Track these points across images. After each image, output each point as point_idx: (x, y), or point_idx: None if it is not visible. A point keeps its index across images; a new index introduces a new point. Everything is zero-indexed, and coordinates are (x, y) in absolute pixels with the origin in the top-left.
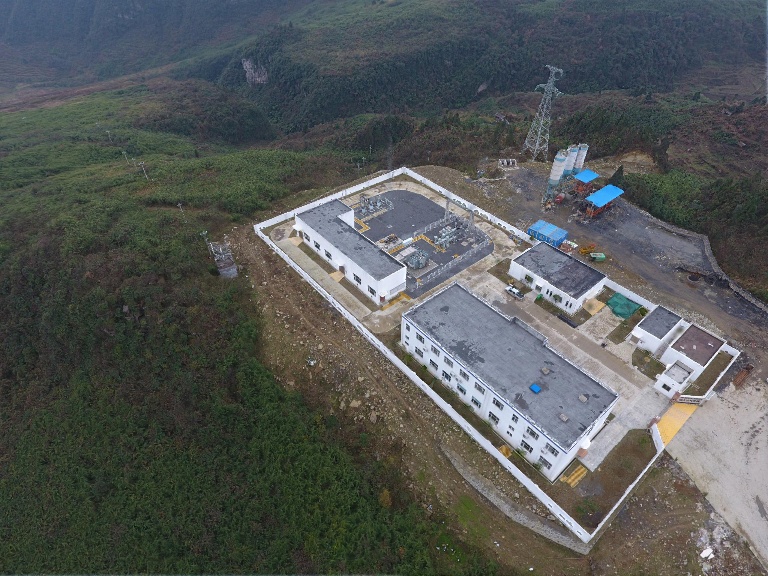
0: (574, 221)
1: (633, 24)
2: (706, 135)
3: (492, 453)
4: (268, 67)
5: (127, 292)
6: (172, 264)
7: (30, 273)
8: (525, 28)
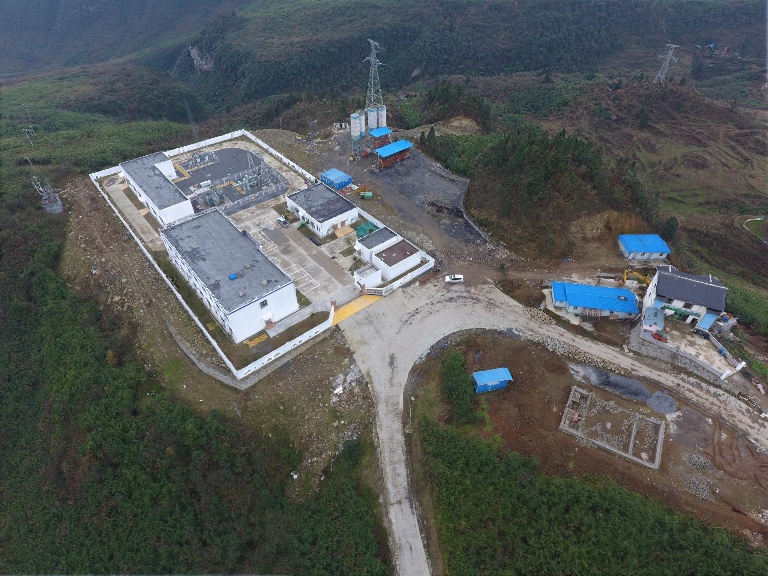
0: (369, 170)
1: (557, 10)
2: (588, 110)
3: None
4: None
5: None
6: (3, 201)
7: None
8: (456, 15)
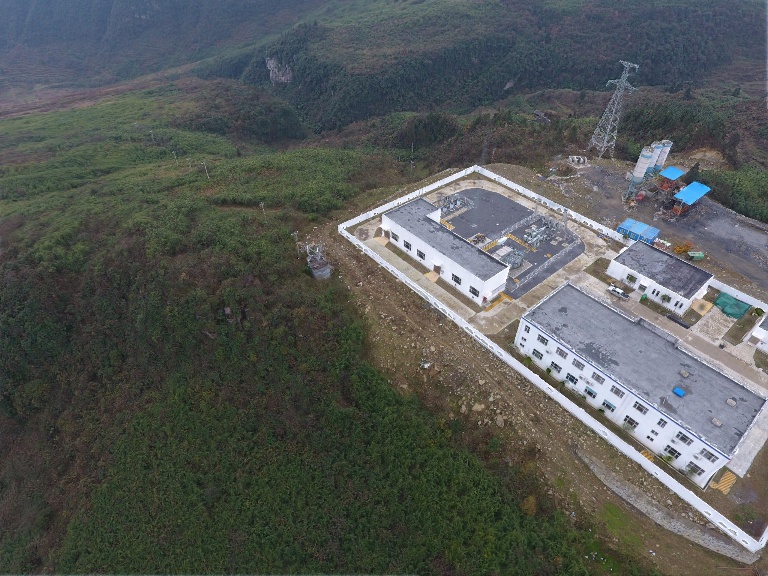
0: (660, 219)
1: (662, 20)
2: (751, 131)
3: (634, 458)
4: (293, 66)
5: (228, 294)
6: (267, 265)
7: (115, 274)
8: (552, 25)
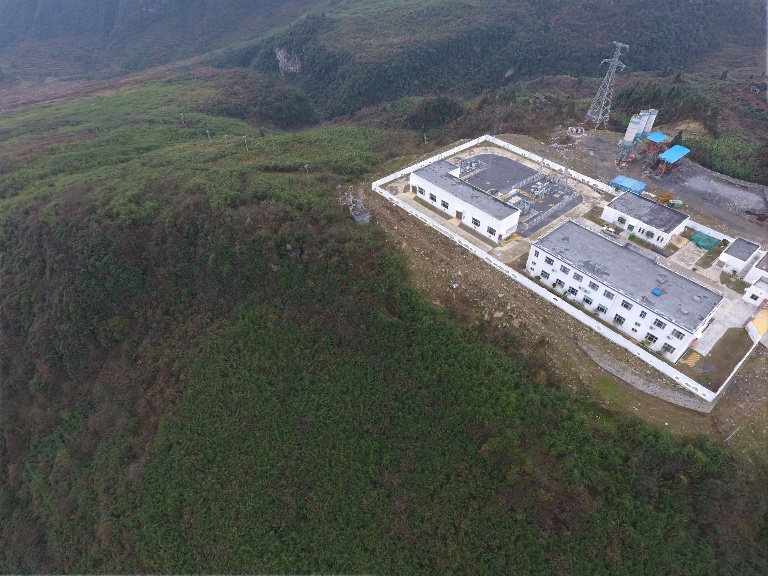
0: (647, 177)
1: (655, 9)
2: (736, 111)
3: (622, 345)
4: (301, 56)
5: (288, 233)
6: (317, 212)
7: (185, 225)
8: (550, 14)
